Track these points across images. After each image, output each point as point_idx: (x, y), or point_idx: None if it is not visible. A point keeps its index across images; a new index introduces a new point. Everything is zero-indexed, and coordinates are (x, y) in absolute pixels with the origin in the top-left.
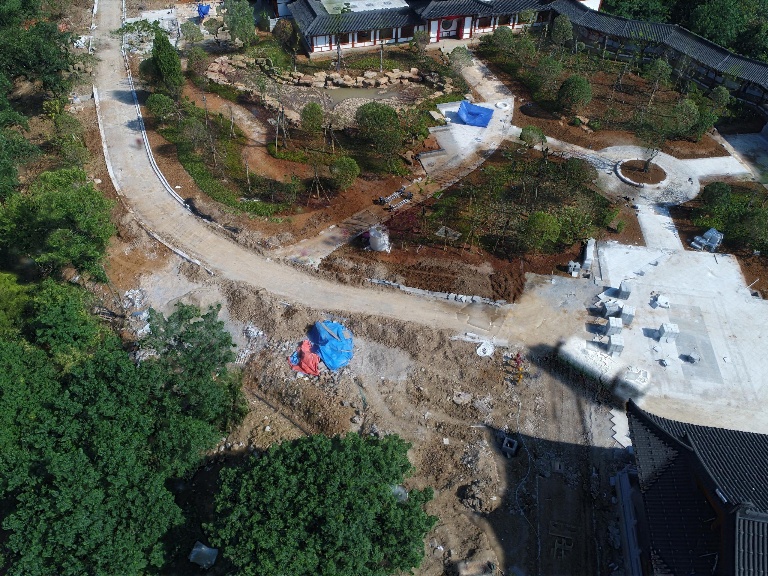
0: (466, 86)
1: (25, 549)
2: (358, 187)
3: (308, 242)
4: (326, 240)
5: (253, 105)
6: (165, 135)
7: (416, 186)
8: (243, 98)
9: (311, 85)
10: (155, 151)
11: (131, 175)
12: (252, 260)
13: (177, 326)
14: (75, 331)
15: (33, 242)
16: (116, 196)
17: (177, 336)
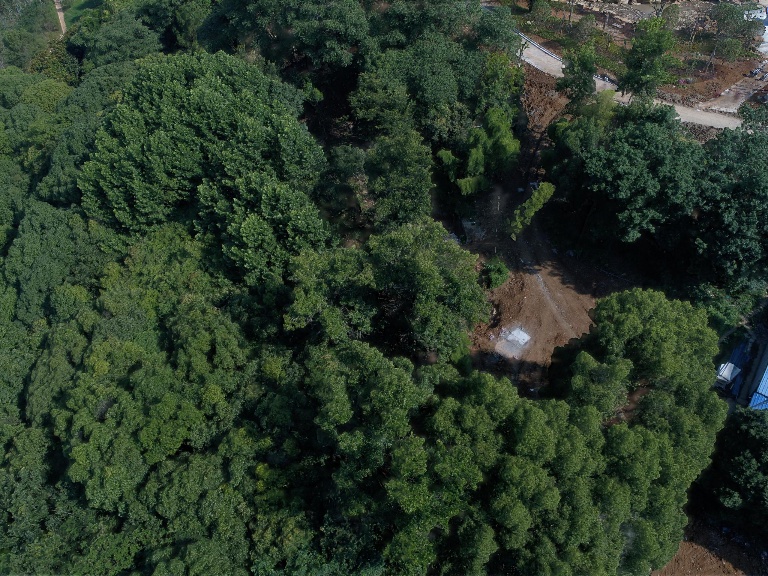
0: (749, 0)
1: (747, 228)
2: (726, 66)
3: (717, 99)
4: (730, 98)
5: (593, 14)
6: (543, 35)
7: (767, 66)
8: (580, 10)
9: (619, 2)
10: (543, 46)
11: (540, 61)
12: (686, 110)
13: (766, 114)
14: (680, 124)
15: (591, 80)
16: (545, 74)
17: (764, 121)
